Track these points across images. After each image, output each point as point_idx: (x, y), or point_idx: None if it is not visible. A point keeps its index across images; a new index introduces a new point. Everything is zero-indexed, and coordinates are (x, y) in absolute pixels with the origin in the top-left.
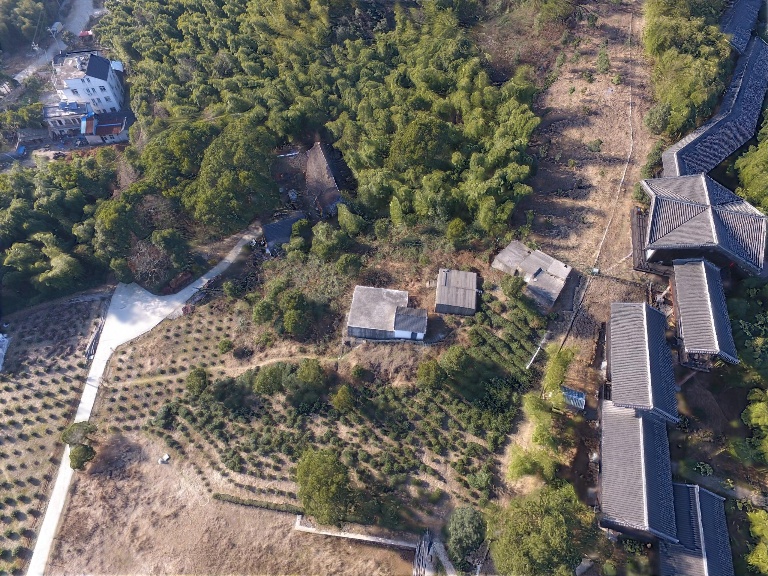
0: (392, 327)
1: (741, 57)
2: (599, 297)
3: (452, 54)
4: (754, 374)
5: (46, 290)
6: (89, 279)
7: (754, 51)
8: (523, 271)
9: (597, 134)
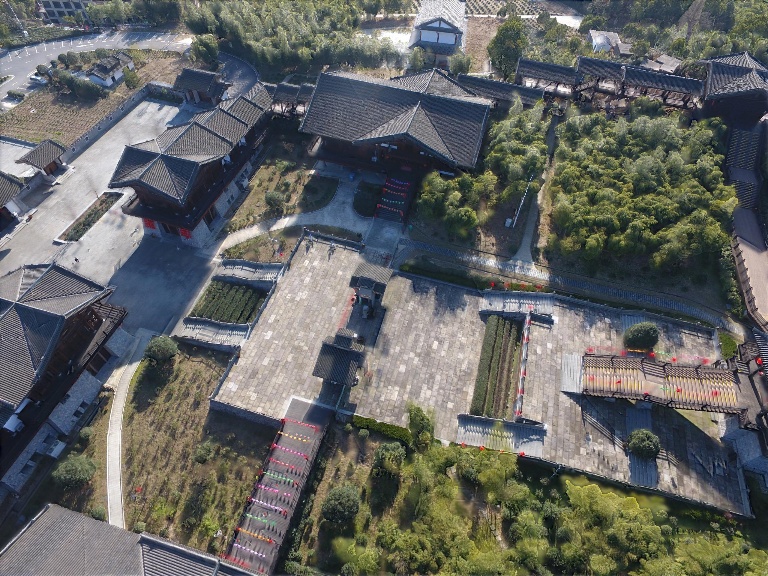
0: None
1: None
2: None
3: None
4: None
5: None
6: (585, 10)
7: None
8: None
9: None
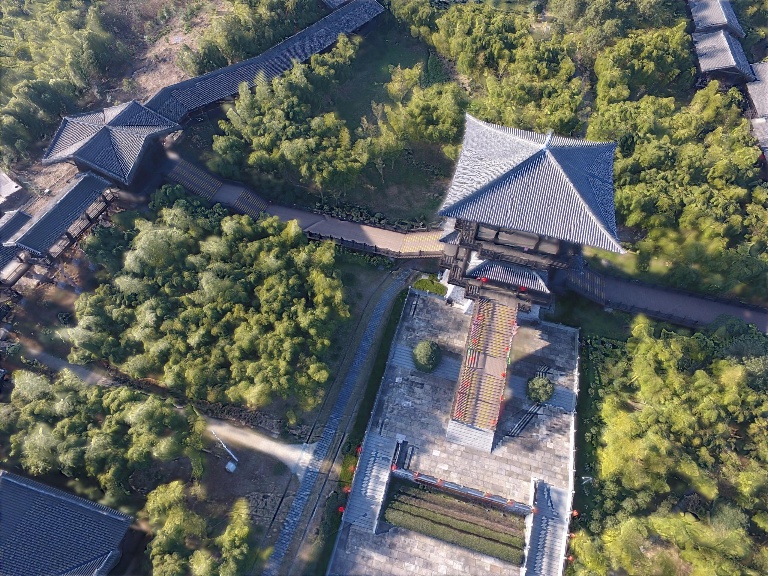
0: None
1: (333, 11)
2: (36, 213)
3: (56, 7)
4: (108, 272)
5: None
6: None
7: (350, 6)
8: None
9: (156, 78)
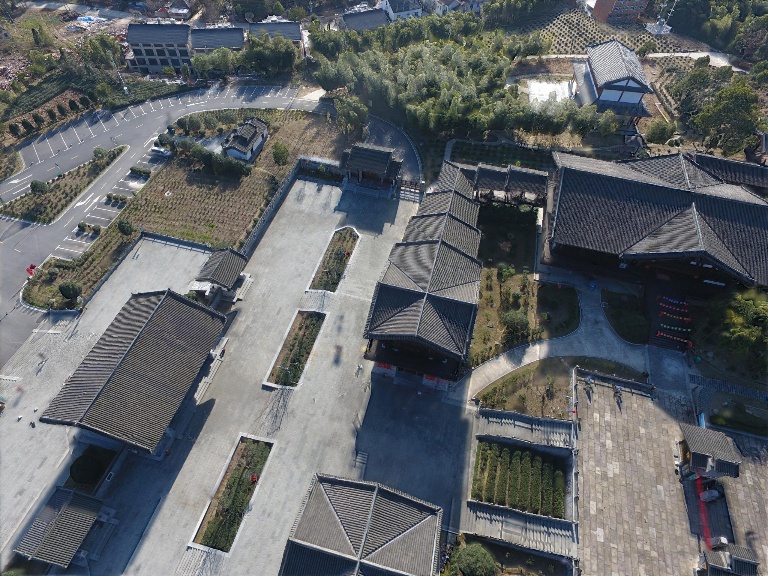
0: None
1: None
2: None
3: None
4: None
5: (703, 32)
6: (718, 44)
7: None
8: None
9: None
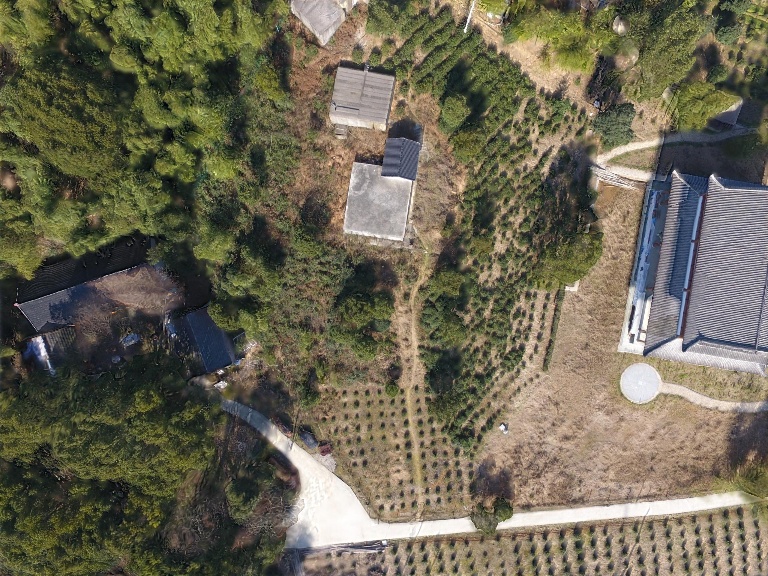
0: (406, 184)
1: None
2: None
3: None
4: None
5: None
6: None
7: None
8: (348, 0)
9: None
